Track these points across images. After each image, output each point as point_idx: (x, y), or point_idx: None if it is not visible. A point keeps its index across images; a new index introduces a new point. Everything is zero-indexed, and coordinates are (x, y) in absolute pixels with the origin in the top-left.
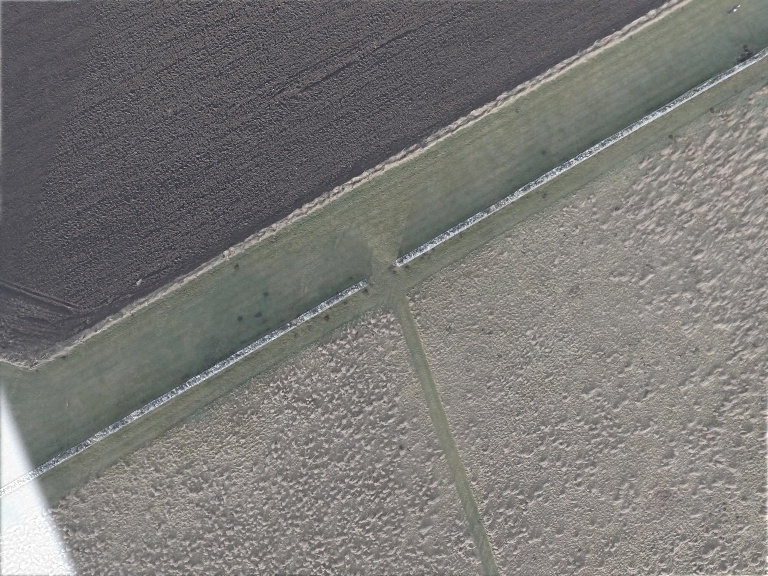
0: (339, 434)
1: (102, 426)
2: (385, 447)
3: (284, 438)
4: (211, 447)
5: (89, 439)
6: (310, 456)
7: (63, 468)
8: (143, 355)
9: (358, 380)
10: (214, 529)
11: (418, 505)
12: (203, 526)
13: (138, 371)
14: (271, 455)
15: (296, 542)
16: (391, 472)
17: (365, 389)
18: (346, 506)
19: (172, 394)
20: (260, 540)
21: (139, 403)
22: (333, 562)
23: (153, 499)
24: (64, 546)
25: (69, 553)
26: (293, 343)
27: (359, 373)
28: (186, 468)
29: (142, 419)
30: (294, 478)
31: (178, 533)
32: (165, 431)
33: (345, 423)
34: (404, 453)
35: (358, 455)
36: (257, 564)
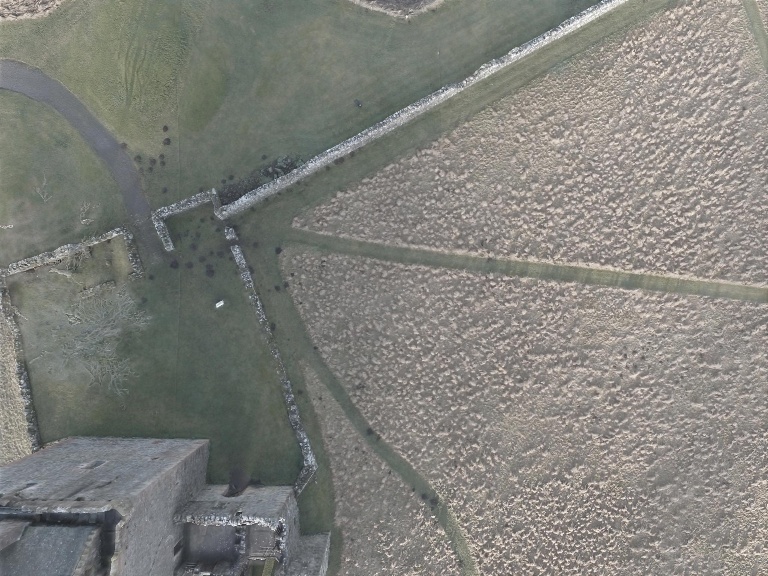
0: (686, 94)
1: (473, 72)
2: (730, 107)
3: (635, 95)
4: (572, 97)
5: (466, 79)
6: (662, 111)
7: (434, 113)
8: (507, 10)
9: (703, 44)
10: (573, 176)
11: (762, 162)
12: (563, 173)
13: (504, 24)
14: (625, 109)
15: (649, 192)
16: (736, 131)
17: (710, 52)
18: (695, 160)
19: (547, 34)
20: (616, 189)
21: (507, 52)
22: (685, 211)
23: (518, 145)
24: (436, 186)
25: (440, 193)
26: (641, 8)
27: (703, 38)
28: (549, 116)
29: (508, 68)
30: (647, 132)
31: (540, 179)
32: (529, 80)
33: (692, 83)
34: (747, 114)
35: (706, 112)
36: (614, 210)
